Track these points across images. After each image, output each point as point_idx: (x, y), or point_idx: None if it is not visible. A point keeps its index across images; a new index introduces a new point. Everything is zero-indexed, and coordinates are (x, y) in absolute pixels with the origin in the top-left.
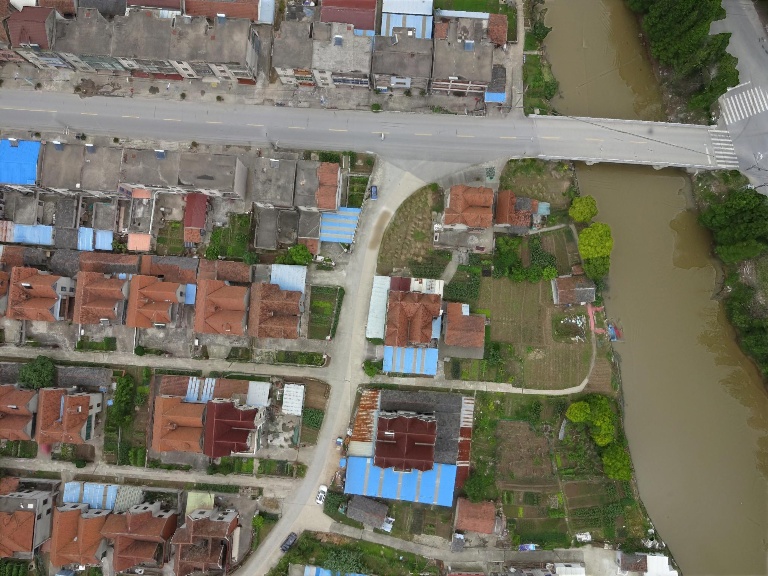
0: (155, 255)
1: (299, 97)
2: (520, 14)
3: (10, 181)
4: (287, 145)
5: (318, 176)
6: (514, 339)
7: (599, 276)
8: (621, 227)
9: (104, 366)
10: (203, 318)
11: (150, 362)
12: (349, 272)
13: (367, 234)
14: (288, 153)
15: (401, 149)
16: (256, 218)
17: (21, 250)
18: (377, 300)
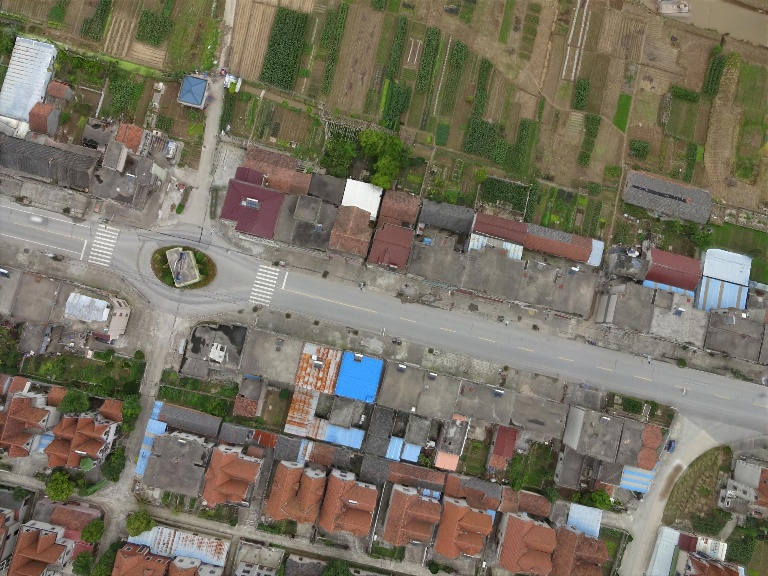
0: (462, 477)
1: (609, 338)
2: None
3: (349, 394)
4: (593, 384)
5: (642, 439)
6: None
7: None
8: None
9: (392, 574)
10: (516, 559)
11: (435, 575)
12: (636, 518)
13: (658, 484)
14: (592, 391)
15: (700, 407)
16: (554, 450)
17: (332, 451)
18: (664, 553)
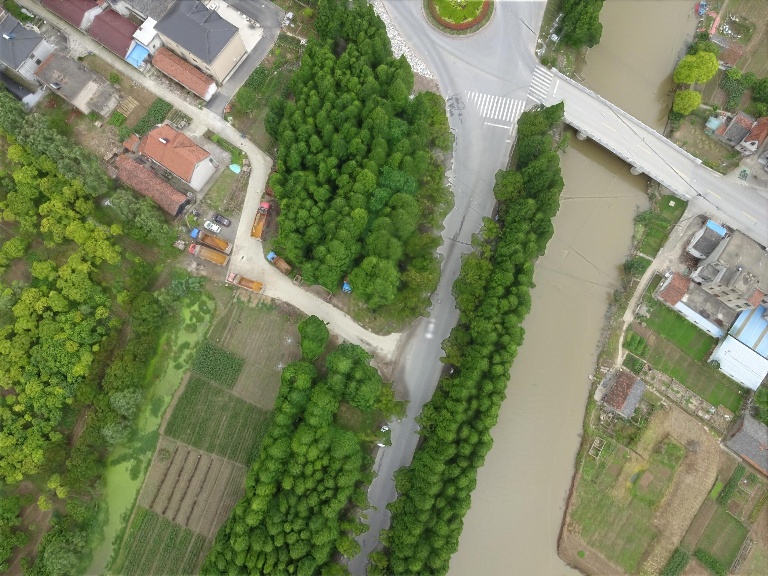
0: None
1: None
2: (638, 295)
3: None
4: None
5: None
6: None
7: None
8: (623, 93)
9: None
10: None
11: None
12: None
13: None
14: None
15: None
16: None
17: None
18: None
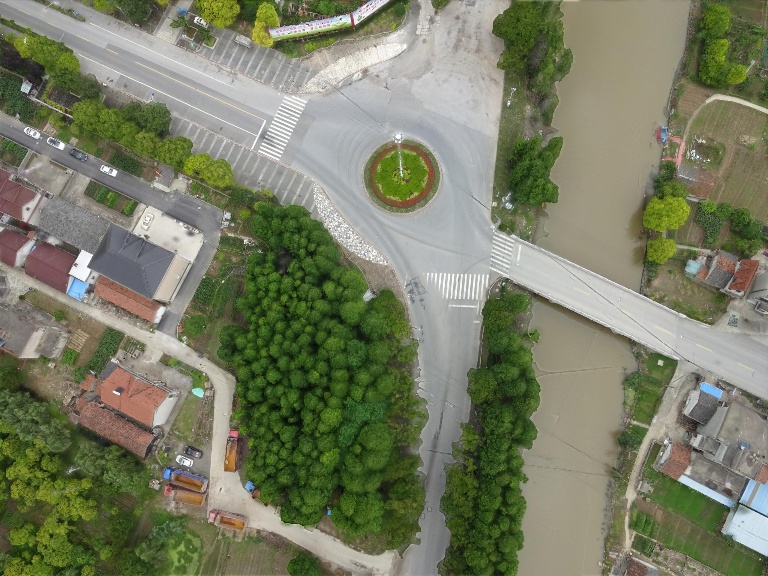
0: None
1: None
2: (638, 468)
3: None
4: None
5: None
6: (763, 161)
7: (676, 182)
8: (592, 231)
9: None
10: None
11: None
12: None
13: None
14: None
15: None
16: None
17: None
18: None
